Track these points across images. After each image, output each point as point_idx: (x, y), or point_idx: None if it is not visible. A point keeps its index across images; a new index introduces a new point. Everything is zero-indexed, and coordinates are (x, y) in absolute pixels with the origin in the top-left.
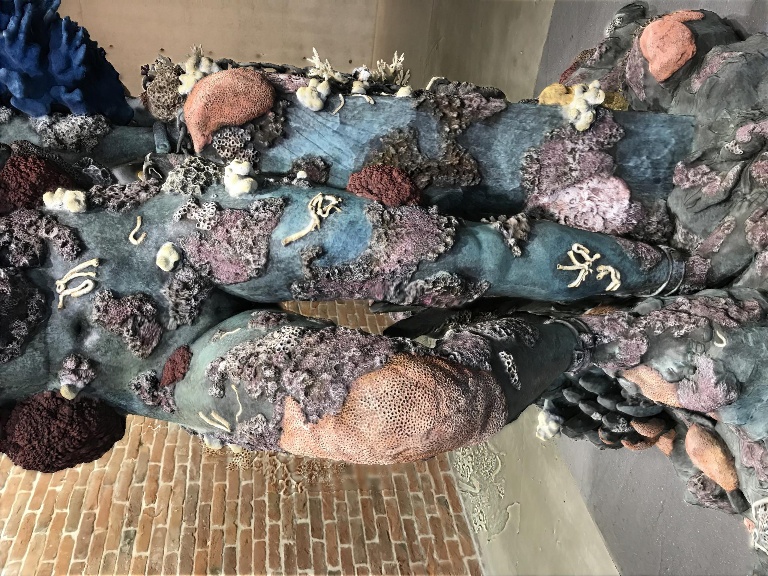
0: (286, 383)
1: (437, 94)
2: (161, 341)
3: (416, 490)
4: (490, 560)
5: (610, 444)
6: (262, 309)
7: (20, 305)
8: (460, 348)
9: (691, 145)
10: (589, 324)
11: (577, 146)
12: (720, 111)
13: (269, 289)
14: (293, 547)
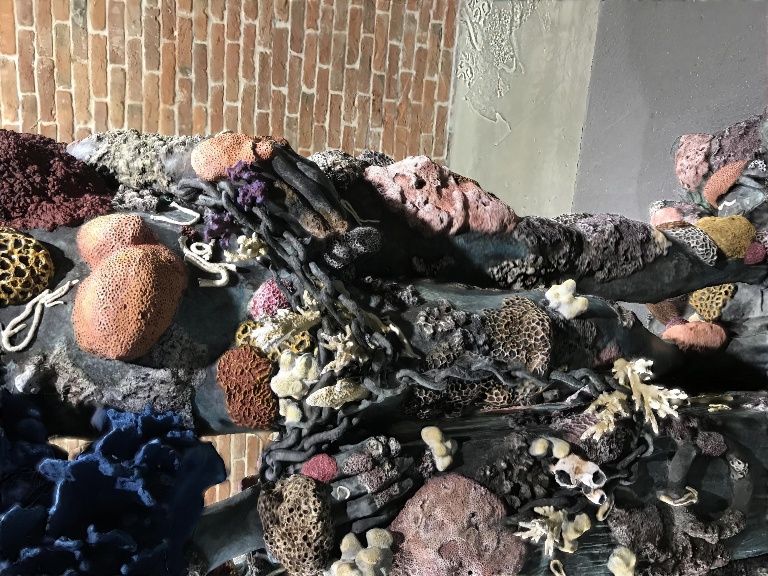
0: None
1: (658, 575)
2: None
3: (414, 8)
4: (459, 116)
5: None
6: None
7: None
8: None
9: None
10: None
11: None
12: None
13: None
14: (269, 57)
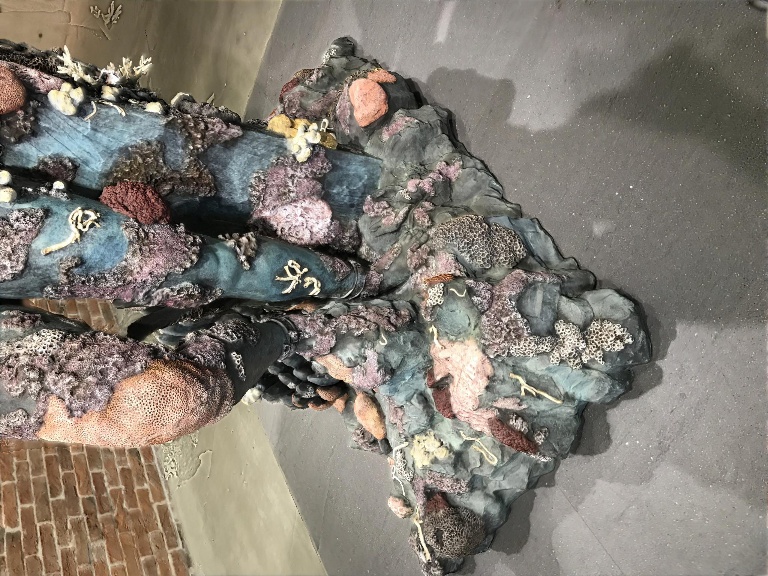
0: (51, 383)
1: (184, 115)
2: None
3: None
4: (179, 504)
5: None
6: (10, 306)
7: None
8: (202, 351)
9: (378, 181)
10: (296, 323)
11: (296, 173)
12: (399, 161)
13: (21, 290)
14: None
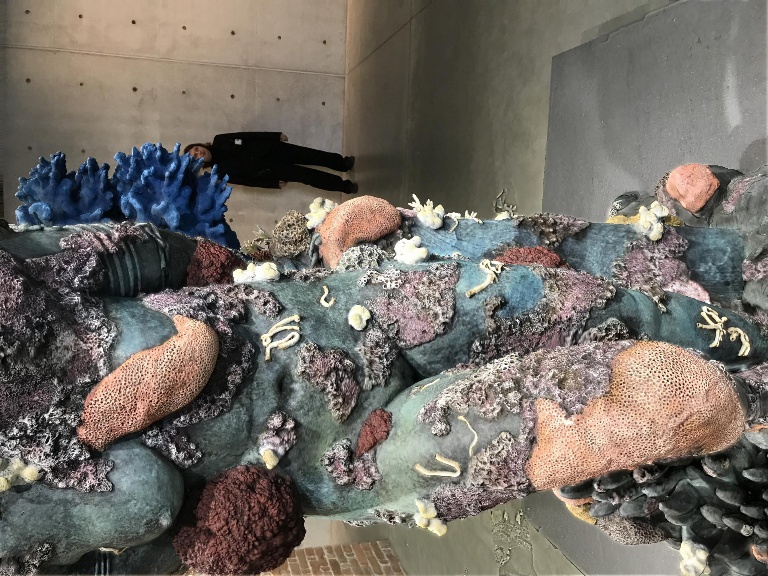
0: (531, 387)
1: None
2: (357, 403)
3: None
4: None
5: (765, 571)
6: None
7: (236, 351)
8: None
9: (744, 252)
10: (744, 377)
11: (654, 255)
12: (762, 218)
13: (450, 351)
14: None
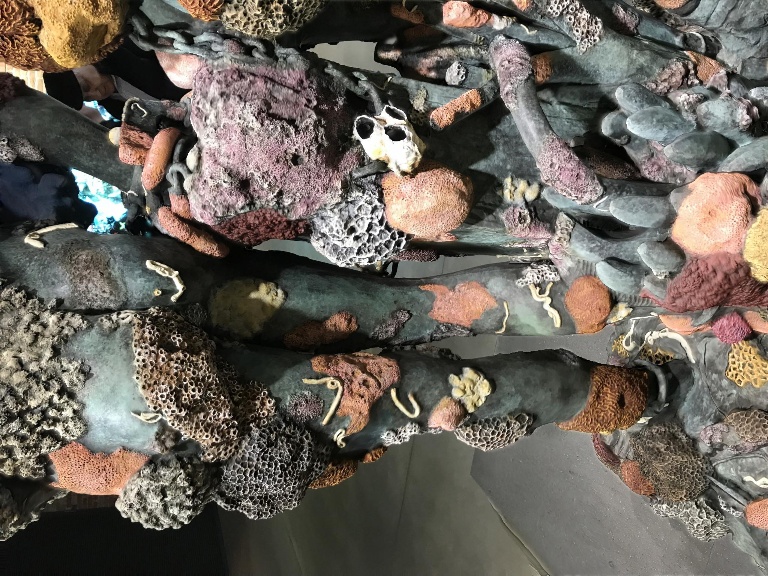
0: None
1: None
2: None
3: None
4: None
5: None
6: None
7: None
8: None
9: None
10: None
11: None
12: None
13: None
14: None
